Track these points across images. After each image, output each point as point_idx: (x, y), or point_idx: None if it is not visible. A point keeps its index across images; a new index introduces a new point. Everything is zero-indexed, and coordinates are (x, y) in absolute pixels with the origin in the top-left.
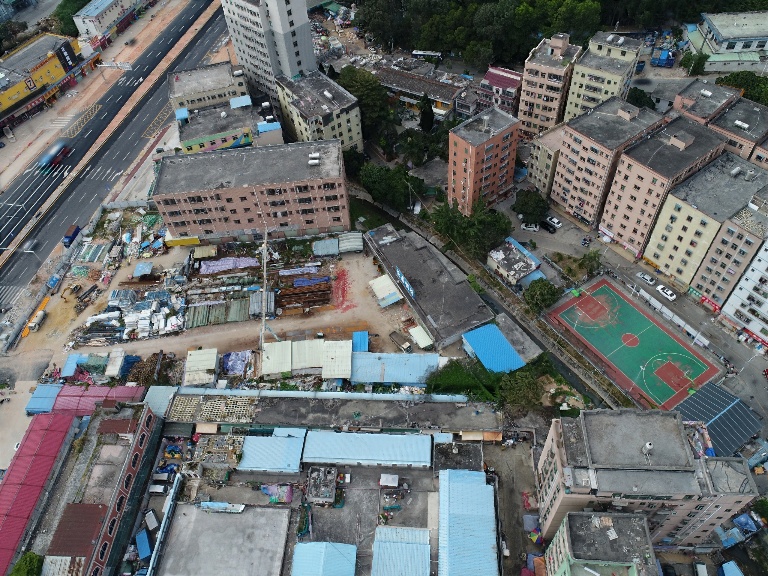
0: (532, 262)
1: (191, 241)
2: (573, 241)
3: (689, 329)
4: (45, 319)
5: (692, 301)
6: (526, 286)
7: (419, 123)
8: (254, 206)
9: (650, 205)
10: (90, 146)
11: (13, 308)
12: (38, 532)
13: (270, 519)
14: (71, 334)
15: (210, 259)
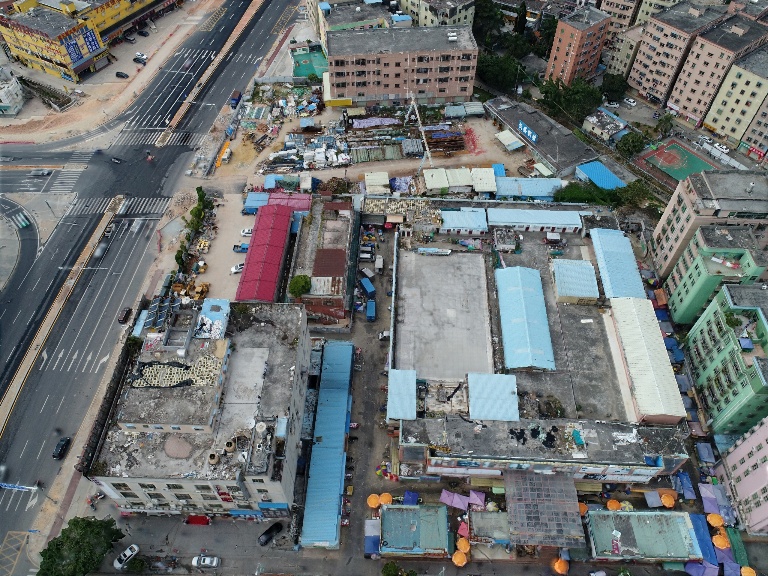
0: (620, 124)
1: (345, 102)
2: (646, 115)
3: (742, 168)
4: (231, 156)
5: (741, 154)
6: (618, 139)
7: (513, 28)
8: (404, 72)
9: (715, 77)
10: (227, 38)
11: (201, 148)
12: (296, 268)
13: (470, 259)
14: (258, 165)
15: (359, 118)
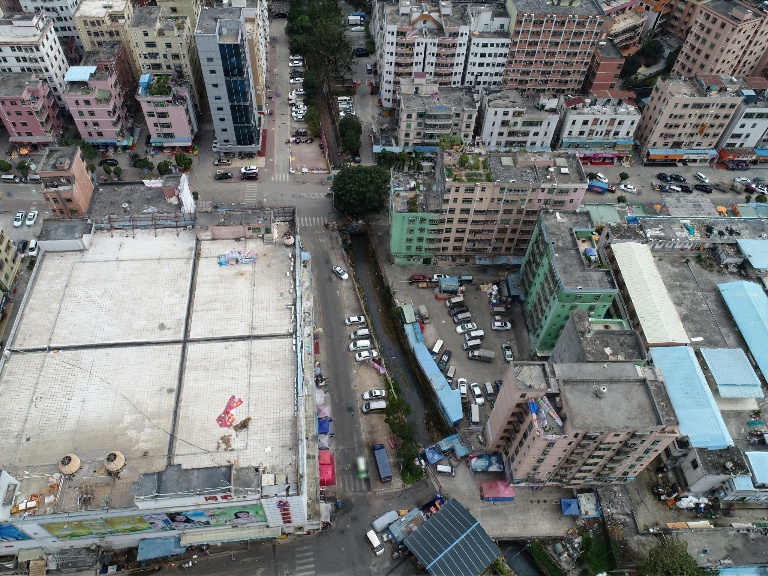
0: None
1: None
2: None
3: None
4: None
5: None
6: None
7: None
8: None
9: None
10: None
11: None
12: None
13: None
14: None
15: None
